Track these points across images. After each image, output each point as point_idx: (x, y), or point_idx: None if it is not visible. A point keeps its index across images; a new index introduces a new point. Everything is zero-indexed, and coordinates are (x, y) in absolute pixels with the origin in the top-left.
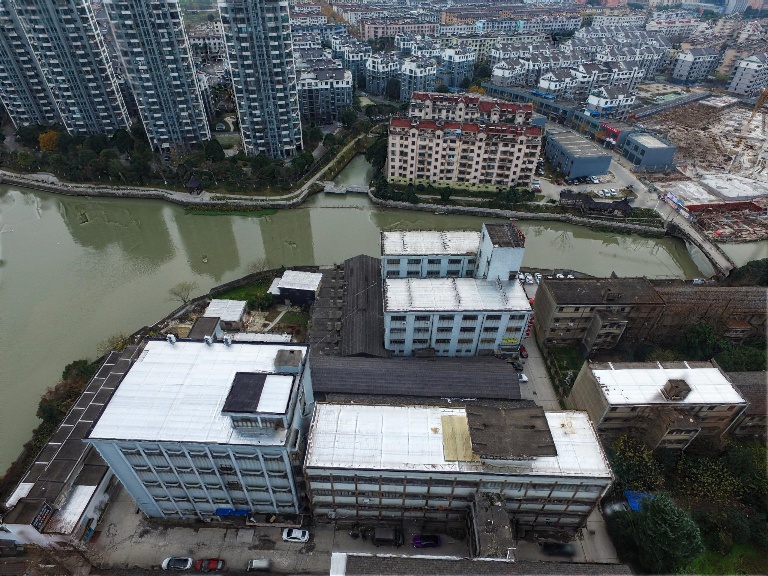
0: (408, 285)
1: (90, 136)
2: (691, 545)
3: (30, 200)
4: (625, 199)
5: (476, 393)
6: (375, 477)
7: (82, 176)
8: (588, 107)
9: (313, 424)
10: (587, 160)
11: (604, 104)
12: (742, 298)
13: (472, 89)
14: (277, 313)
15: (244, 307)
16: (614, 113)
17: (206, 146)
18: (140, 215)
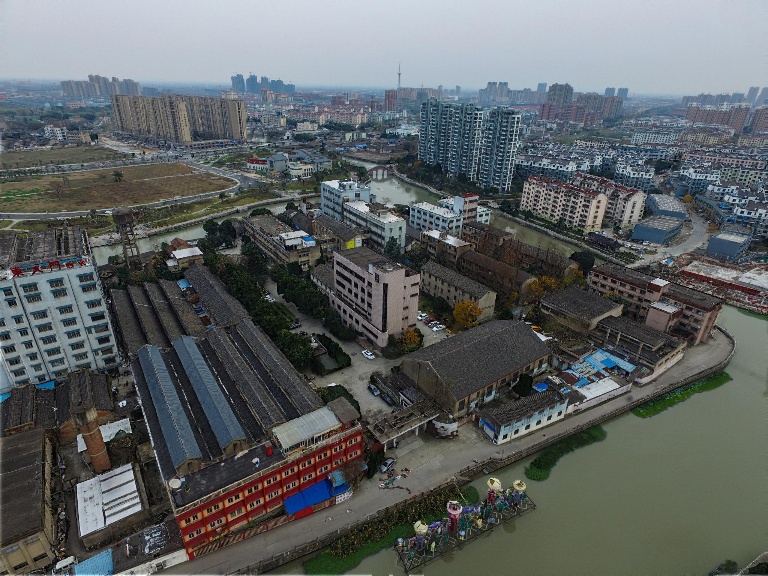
0: (426, 203)
1: (427, 164)
2: (391, 252)
3: (397, 185)
4: (616, 240)
5: (410, 234)
6: (352, 212)
7: (412, 176)
8: (732, 215)
9: (355, 201)
10: (645, 228)
11: (740, 213)
12: (544, 253)
13: (684, 197)
14: (403, 215)
15: (394, 208)
16: (754, 224)
17: (458, 175)
18: (420, 197)
